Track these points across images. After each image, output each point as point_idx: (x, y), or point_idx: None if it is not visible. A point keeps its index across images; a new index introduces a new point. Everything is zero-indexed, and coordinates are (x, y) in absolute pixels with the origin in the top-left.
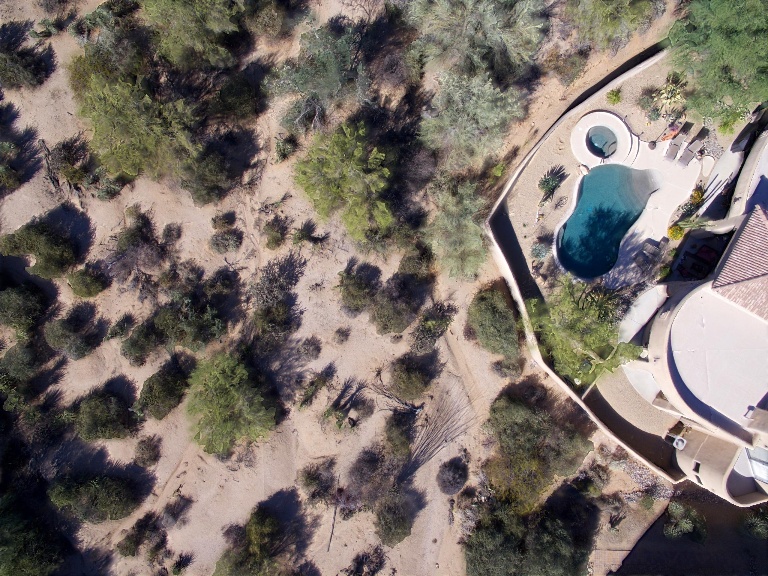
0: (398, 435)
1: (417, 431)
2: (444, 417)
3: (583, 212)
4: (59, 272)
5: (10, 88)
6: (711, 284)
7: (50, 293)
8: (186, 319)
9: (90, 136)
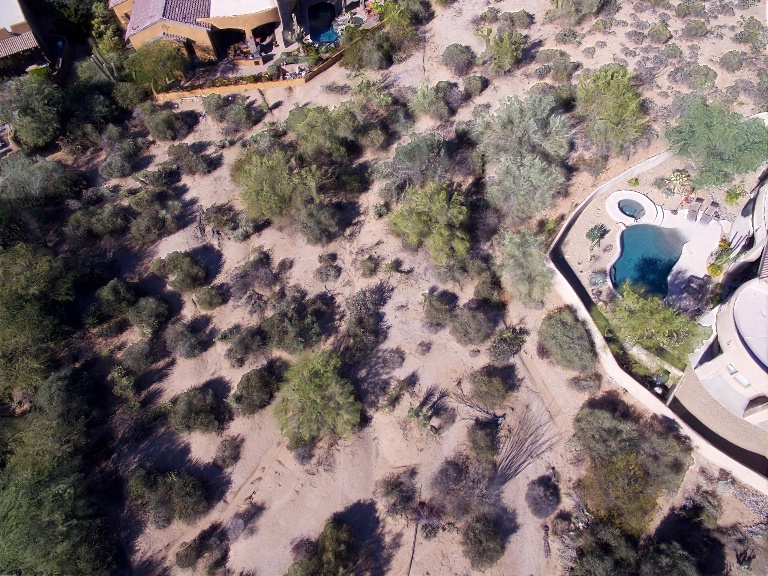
0: (483, 436)
1: (501, 442)
2: (527, 430)
3: (628, 261)
4: (191, 286)
5: (188, 175)
6: (758, 279)
7: (176, 307)
8: (290, 322)
9: (236, 203)
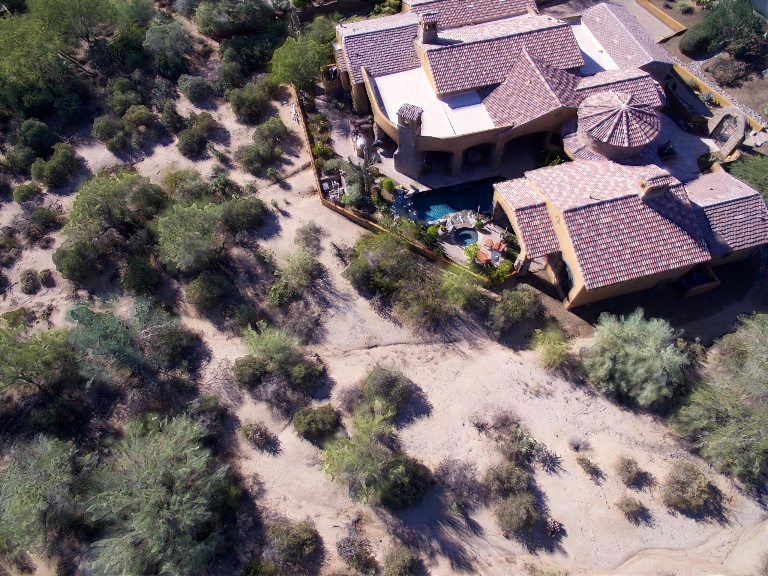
0: None
1: None
2: None
3: None
4: (35, 177)
5: None
6: None
7: None
8: None
9: None
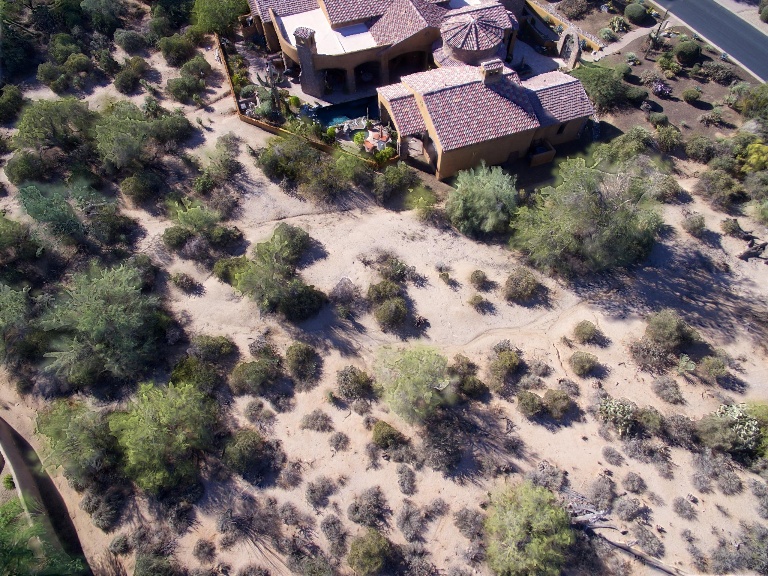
0: None
1: None
2: None
3: None
4: None
5: None
6: None
7: None
8: None
9: None
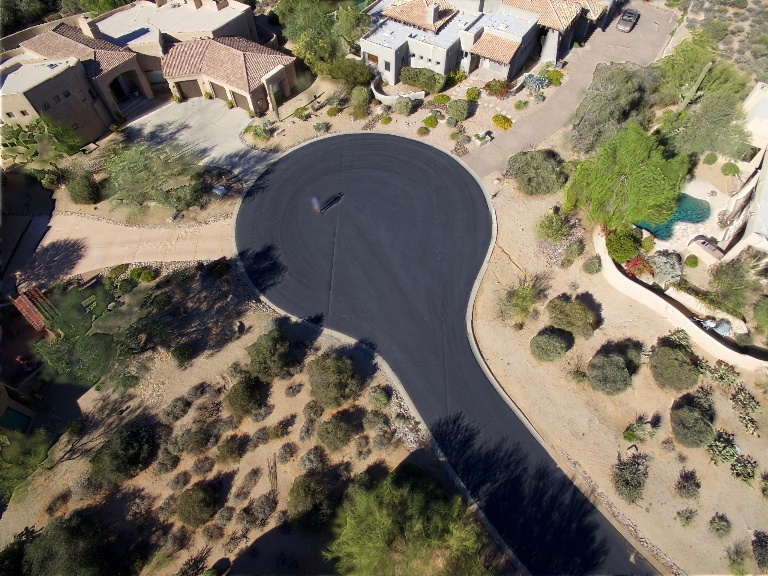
0: None
1: None
2: None
3: None
4: None
5: None
6: None
7: None
8: None
9: None
